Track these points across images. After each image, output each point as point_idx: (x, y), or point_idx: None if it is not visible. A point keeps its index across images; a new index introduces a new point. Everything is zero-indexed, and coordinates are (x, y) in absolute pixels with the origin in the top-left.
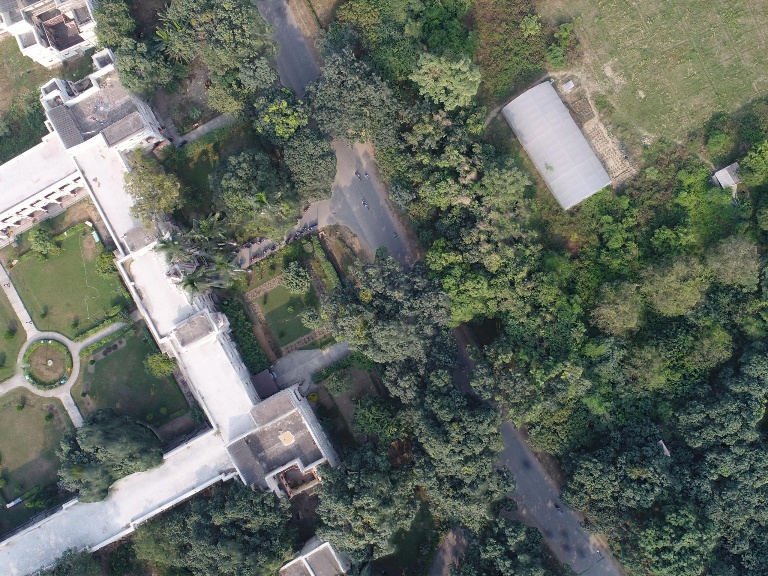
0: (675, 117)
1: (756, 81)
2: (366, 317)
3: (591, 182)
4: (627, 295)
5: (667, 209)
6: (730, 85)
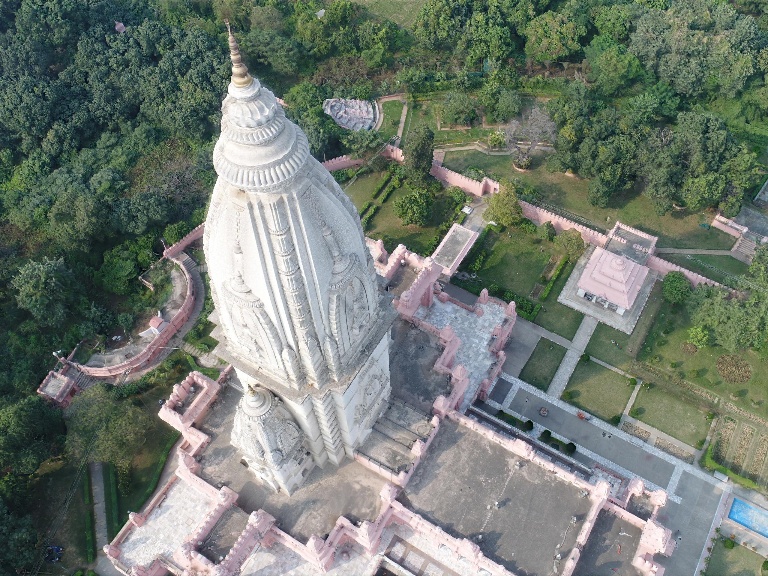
0: None
1: (398, 15)
2: None
3: None
4: None
5: (288, 3)
6: (387, 6)
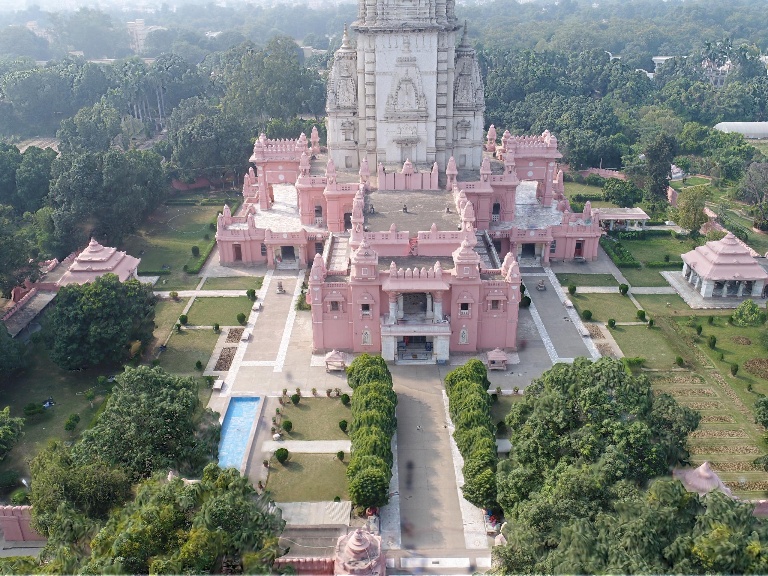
0: (767, 151)
1: None
2: None
3: (730, 123)
4: None
5: None
6: None
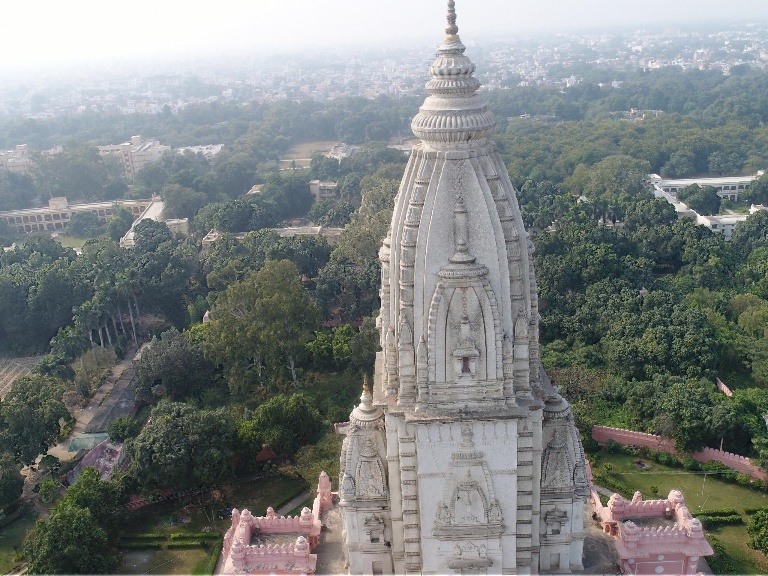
0: None
1: None
2: (764, 217)
3: None
4: (760, 300)
5: None
6: None
